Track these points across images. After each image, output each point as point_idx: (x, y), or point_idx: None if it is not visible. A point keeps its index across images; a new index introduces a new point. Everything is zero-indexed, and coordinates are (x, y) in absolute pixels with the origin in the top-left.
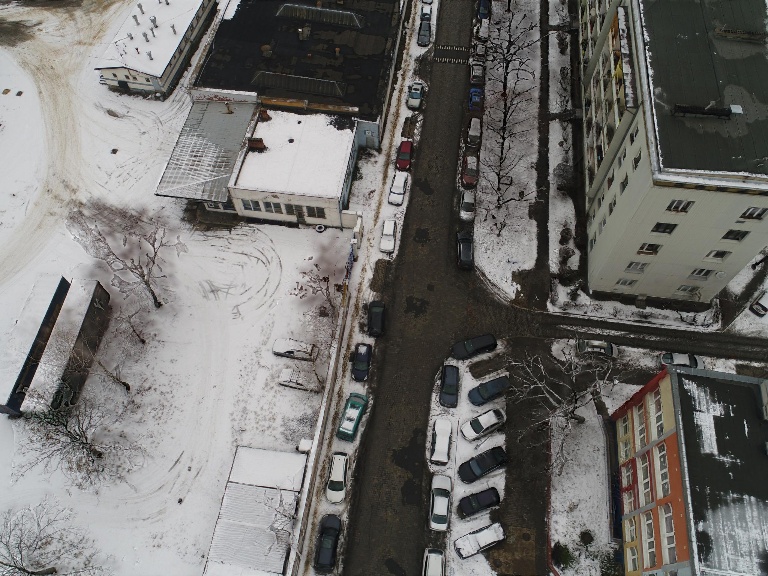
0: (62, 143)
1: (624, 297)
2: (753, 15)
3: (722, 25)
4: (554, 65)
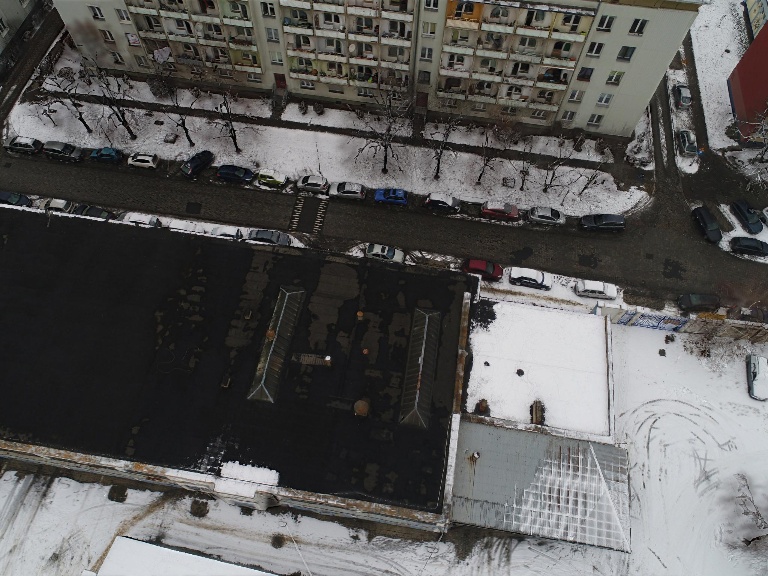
0: None
1: None
2: None
3: None
4: (340, 123)
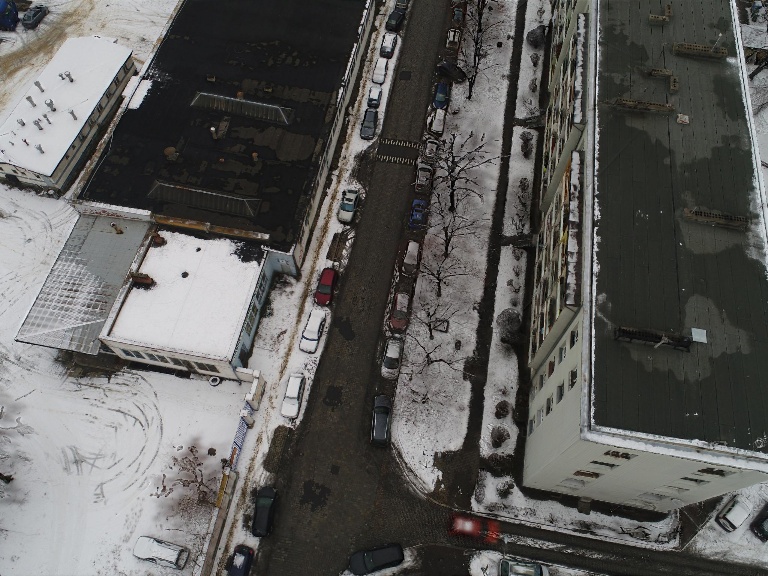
0: None
1: (565, 496)
2: (735, 185)
3: (694, 200)
4: (515, 172)
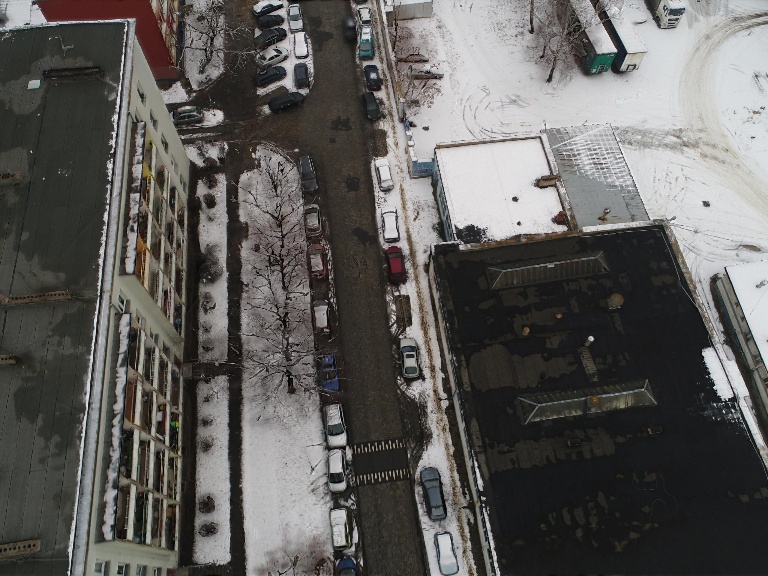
0: (766, 200)
1: None
2: None
3: (6, 198)
4: (221, 472)
